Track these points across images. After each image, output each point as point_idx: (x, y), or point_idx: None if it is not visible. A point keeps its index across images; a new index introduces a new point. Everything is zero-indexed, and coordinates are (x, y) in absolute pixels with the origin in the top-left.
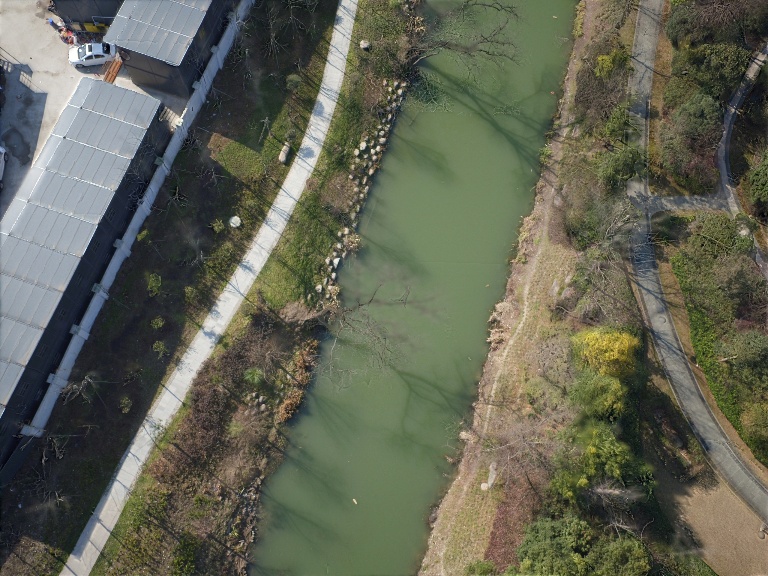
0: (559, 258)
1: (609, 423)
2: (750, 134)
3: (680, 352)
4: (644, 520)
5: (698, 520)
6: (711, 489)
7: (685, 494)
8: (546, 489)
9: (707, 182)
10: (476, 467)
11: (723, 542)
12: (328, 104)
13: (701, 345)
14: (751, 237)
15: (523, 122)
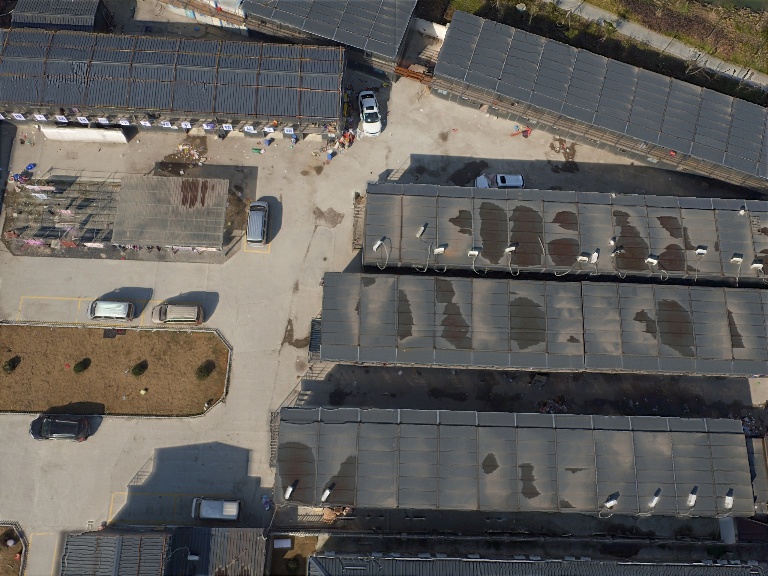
0: None
1: None
2: None
3: None
4: None
5: None
6: None
7: None
8: None
9: None
10: None
11: None
12: None
13: None
14: None
15: None
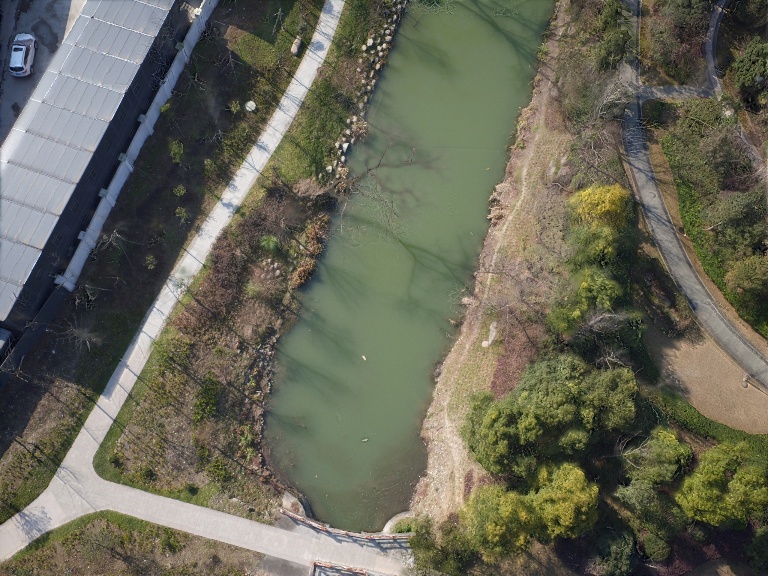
0: (555, 142)
1: (600, 266)
2: (736, 32)
3: (669, 223)
4: (634, 368)
5: (685, 370)
6: (697, 344)
7: (673, 348)
8: (543, 340)
9: (695, 71)
10: (477, 328)
11: (708, 390)
12: (337, 3)
13: (689, 216)
14: (736, 117)
15: (521, 23)
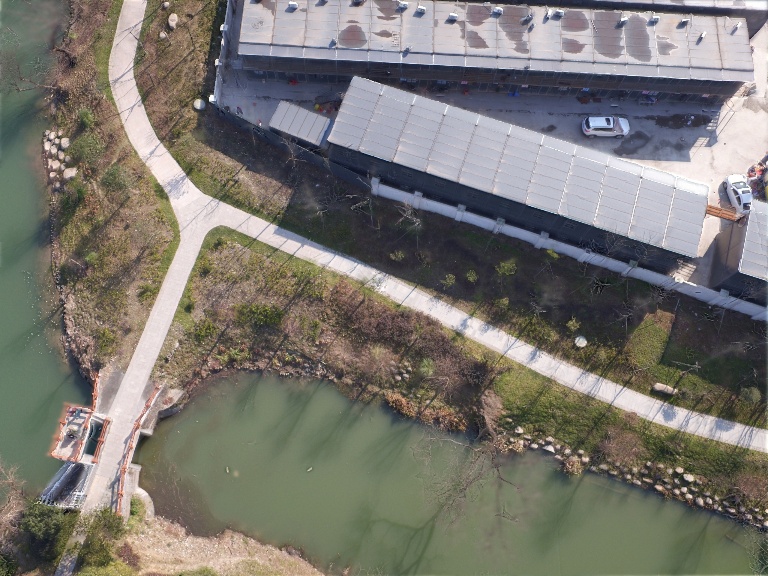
0: None
1: None
2: None
3: None
4: None
5: None
6: None
7: None
8: None
9: None
10: None
11: None
12: (733, 436)
13: None
14: None
15: None
